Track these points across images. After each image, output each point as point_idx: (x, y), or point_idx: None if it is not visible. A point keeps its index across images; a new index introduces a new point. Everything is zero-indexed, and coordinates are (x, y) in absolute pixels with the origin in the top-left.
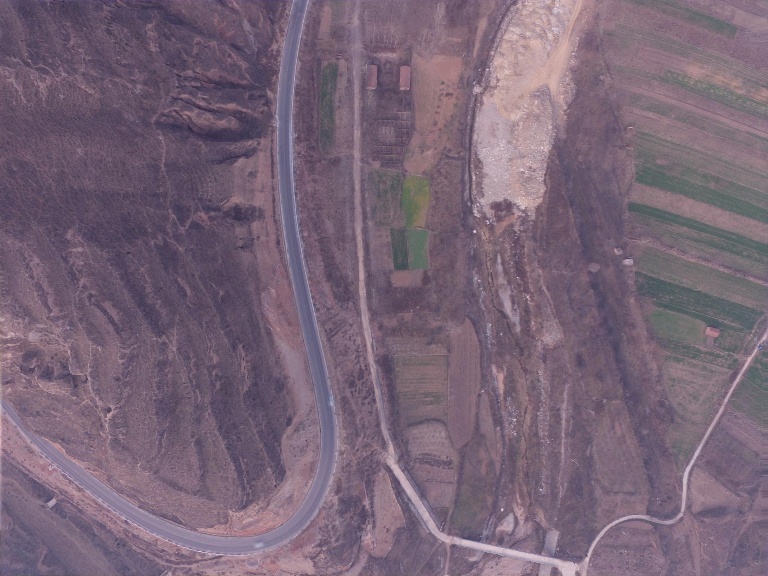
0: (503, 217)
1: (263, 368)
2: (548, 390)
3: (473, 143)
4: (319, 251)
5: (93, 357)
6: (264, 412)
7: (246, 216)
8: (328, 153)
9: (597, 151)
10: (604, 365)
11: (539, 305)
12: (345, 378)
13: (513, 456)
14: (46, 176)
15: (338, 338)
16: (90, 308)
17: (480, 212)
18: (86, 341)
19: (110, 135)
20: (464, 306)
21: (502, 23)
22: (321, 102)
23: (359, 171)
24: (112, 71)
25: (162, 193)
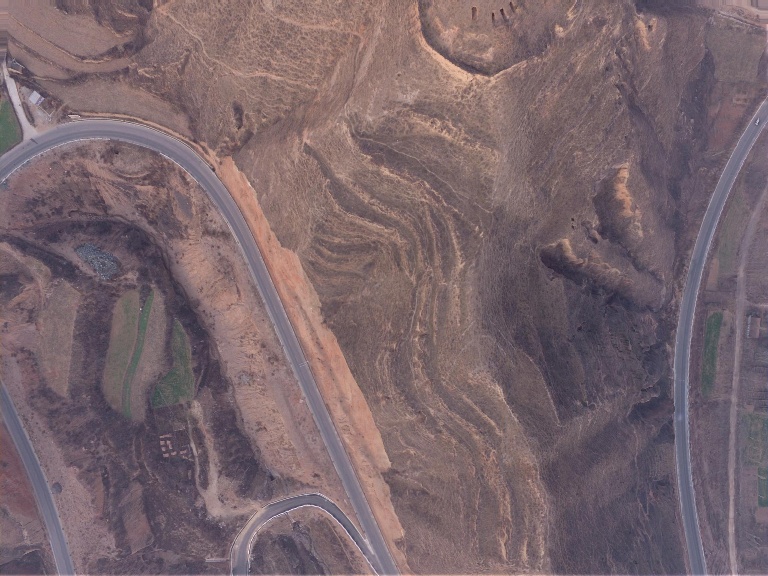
0: None
1: None
2: None
3: None
4: (702, 495)
5: None
6: None
7: (667, 480)
8: (707, 397)
9: None
10: None
11: None
12: None
13: None
14: (590, 505)
15: None
16: None
17: None
18: None
19: (616, 447)
20: None
21: None
22: (704, 349)
23: (735, 415)
24: (614, 382)
25: None
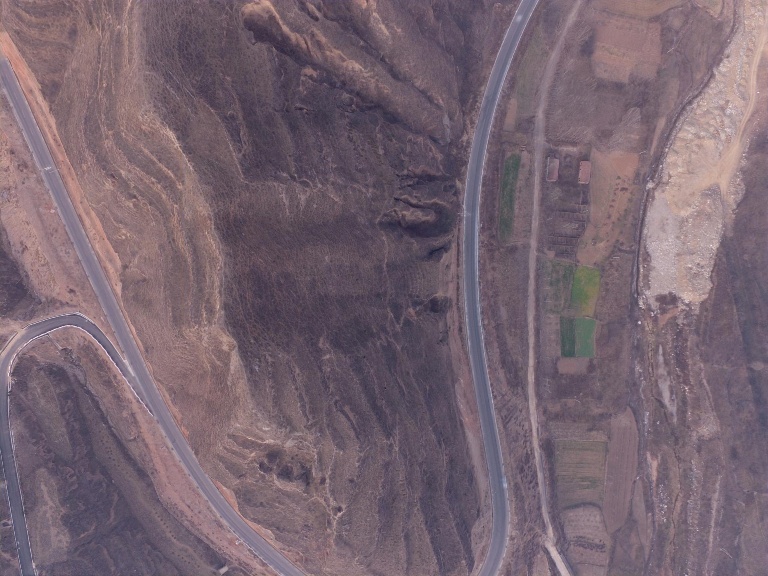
0: (667, 310)
1: (459, 460)
2: (701, 480)
3: (643, 237)
4: (495, 338)
5: (334, 460)
6: (457, 503)
7: (442, 308)
8: (506, 241)
9: (764, 252)
10: (757, 459)
11: (698, 397)
12: (516, 464)
13: (662, 541)
14: (302, 285)
15: (511, 424)
16: (336, 414)
17: (645, 304)
18: (331, 446)
19: (349, 240)
20: (626, 395)
21: (677, 122)
22: (502, 191)
23: (534, 260)
24: (351, 177)
25: (382, 292)
